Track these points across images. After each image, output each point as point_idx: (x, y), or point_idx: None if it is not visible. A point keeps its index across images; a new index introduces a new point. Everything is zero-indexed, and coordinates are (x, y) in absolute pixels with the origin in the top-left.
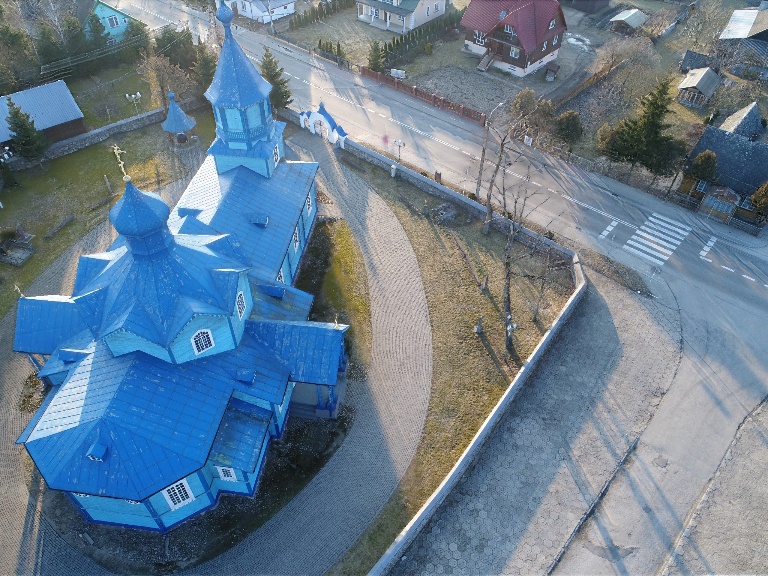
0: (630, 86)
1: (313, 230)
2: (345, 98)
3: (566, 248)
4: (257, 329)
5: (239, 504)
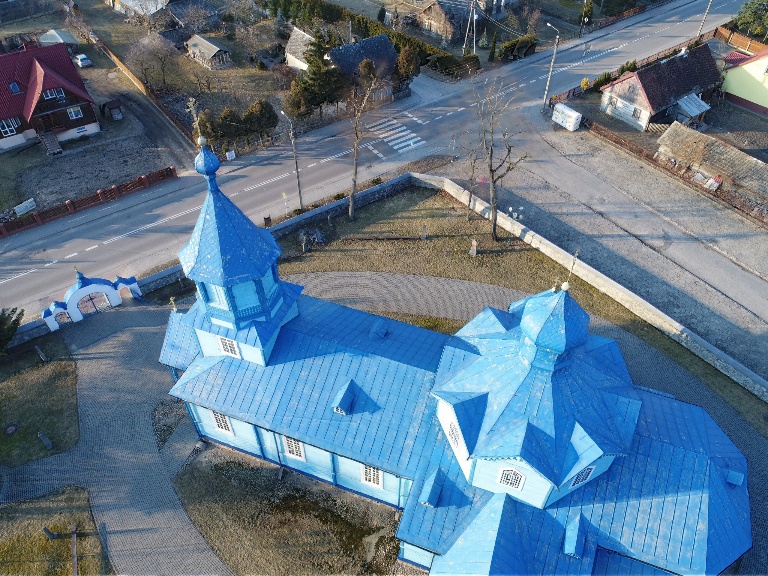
0: (169, 82)
1: None
2: (15, 275)
3: (402, 175)
4: None
5: None
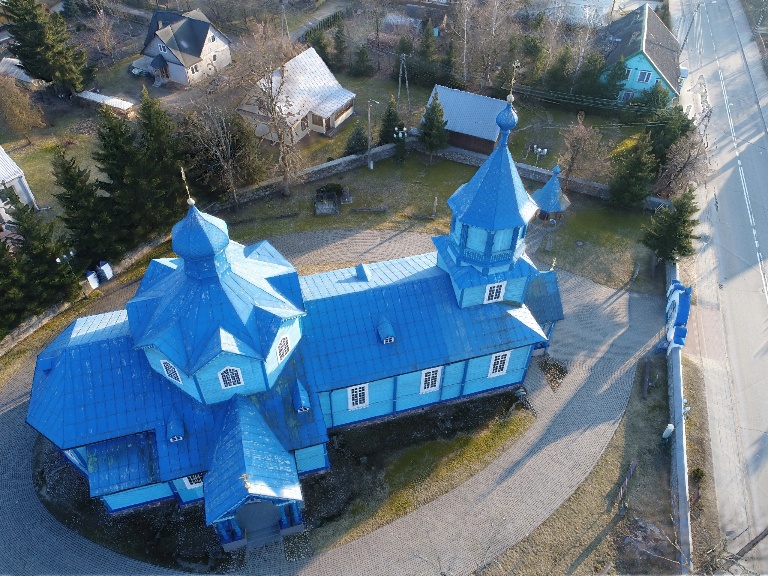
0: None
1: (496, 394)
2: None
3: None
4: (232, 410)
5: (106, 506)
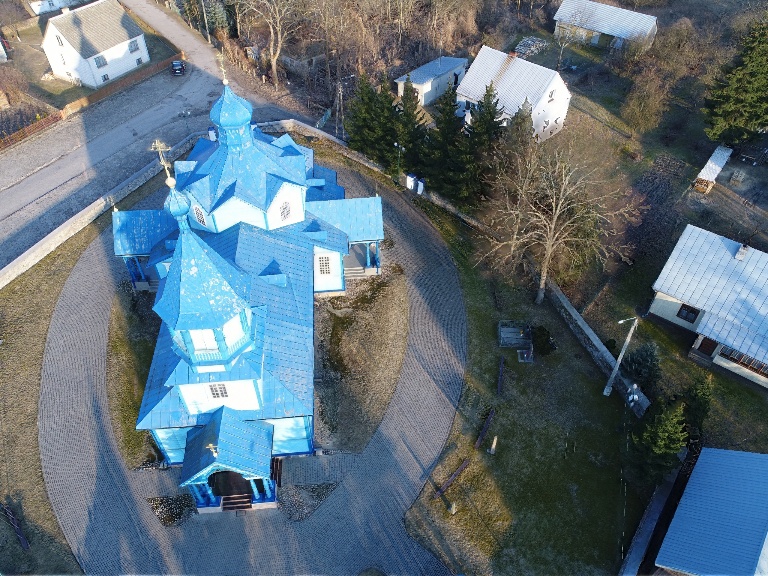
0: None
1: None
2: None
3: None
4: None
5: None
